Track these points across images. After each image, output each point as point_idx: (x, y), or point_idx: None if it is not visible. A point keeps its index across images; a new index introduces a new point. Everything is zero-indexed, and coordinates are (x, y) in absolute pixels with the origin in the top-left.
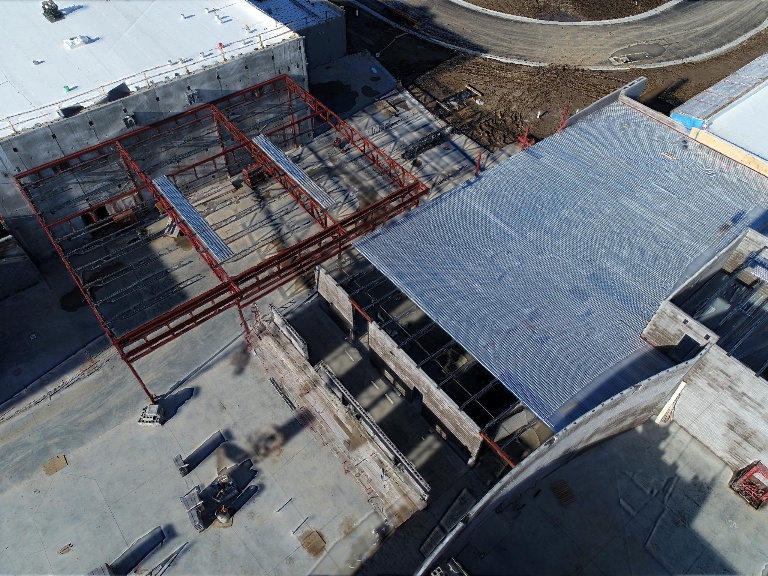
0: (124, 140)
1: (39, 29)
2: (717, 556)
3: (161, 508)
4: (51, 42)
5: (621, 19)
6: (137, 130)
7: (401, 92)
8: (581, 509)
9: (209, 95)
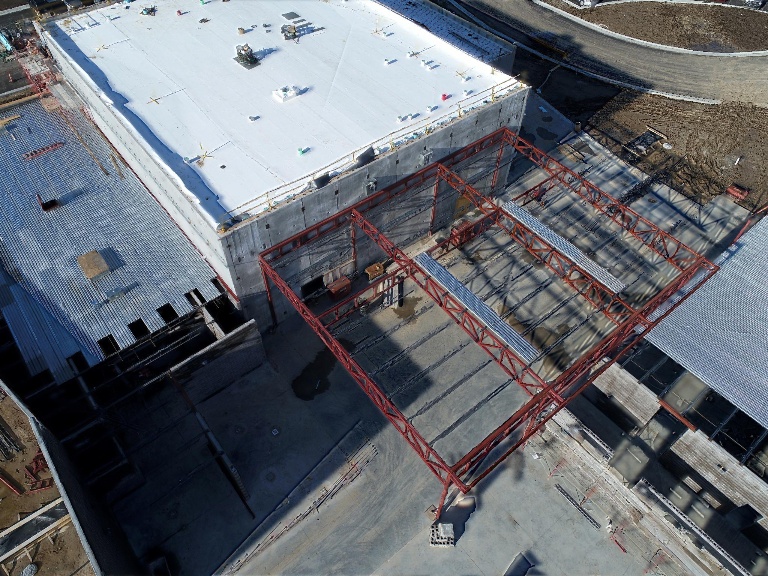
0: (359, 207)
1: (238, 77)
2: None
3: None
4: (257, 93)
5: None
6: (372, 196)
7: (580, 134)
8: None
9: (439, 154)
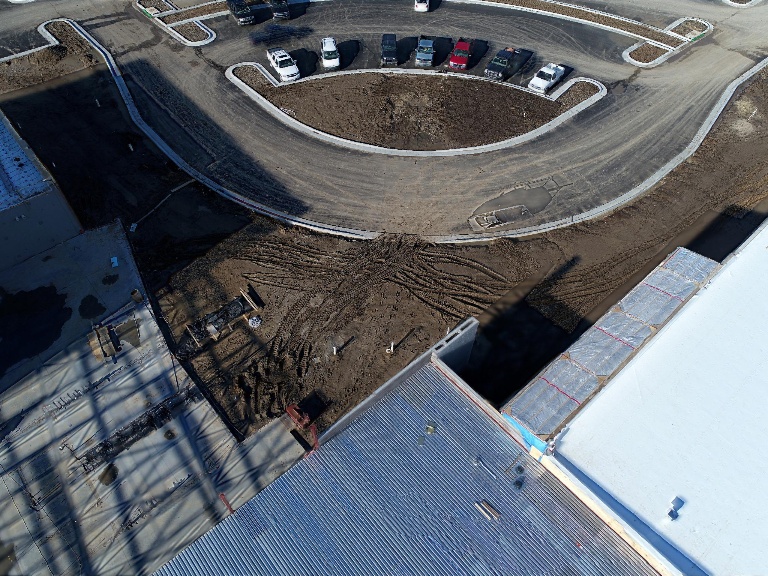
0: None
1: None
2: None
3: None
4: None
5: (499, 143)
6: None
7: (139, 307)
8: None
9: None
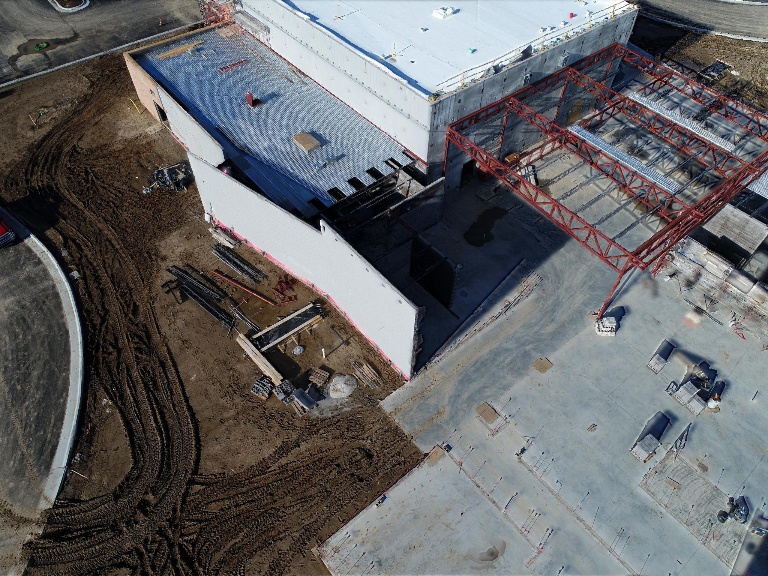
0: (514, 97)
1: (399, 2)
2: None
3: (653, 398)
4: (419, 13)
5: None
6: (524, 88)
7: None
8: None
9: (571, 59)
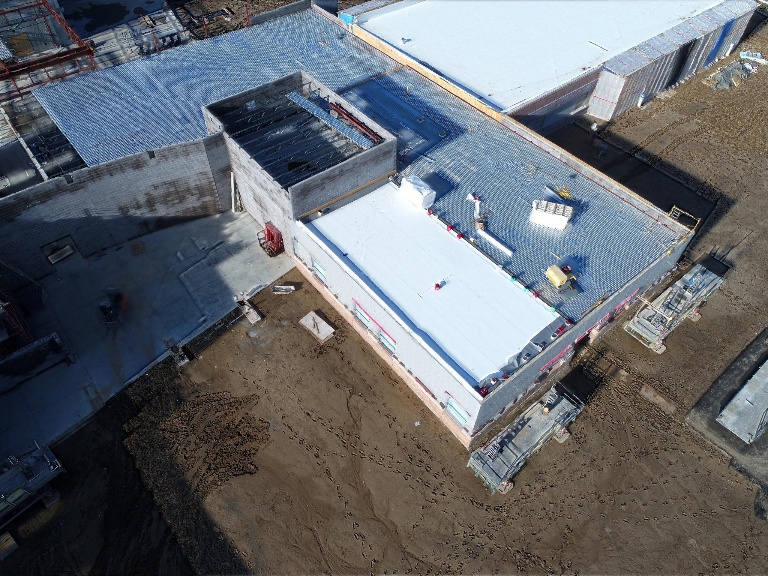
0: None
1: None
2: (226, 281)
3: None
4: None
5: None
6: None
7: (166, 11)
8: (146, 257)
9: None
